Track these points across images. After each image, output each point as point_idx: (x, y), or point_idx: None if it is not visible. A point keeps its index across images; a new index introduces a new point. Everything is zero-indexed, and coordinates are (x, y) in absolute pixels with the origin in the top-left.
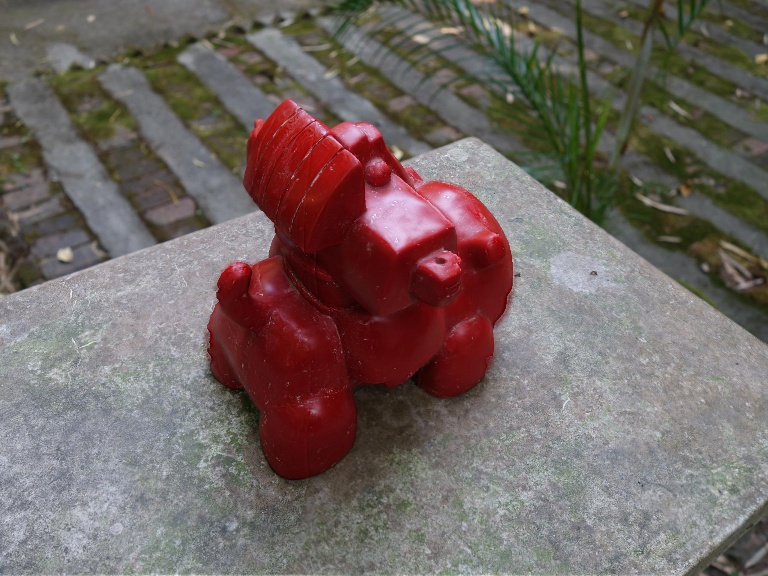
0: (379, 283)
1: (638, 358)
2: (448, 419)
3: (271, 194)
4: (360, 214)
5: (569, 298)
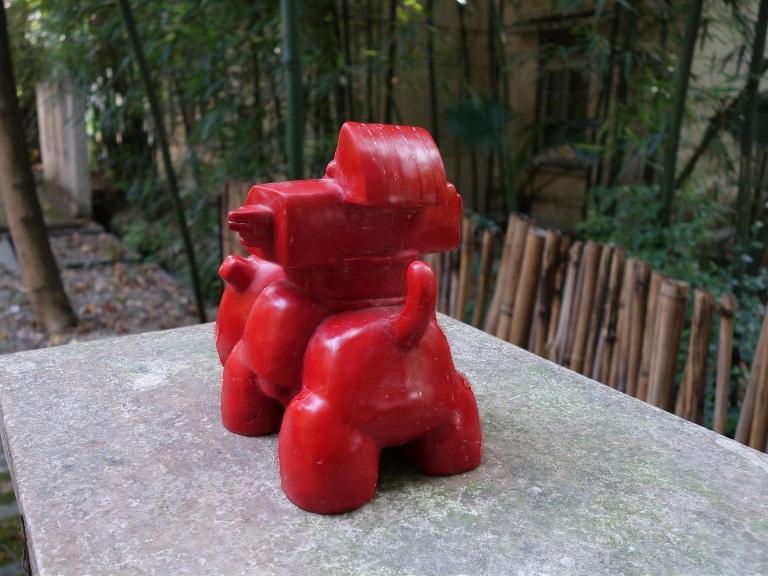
0: (456, 214)
1: None
2: None
3: (411, 180)
4: None
5: None
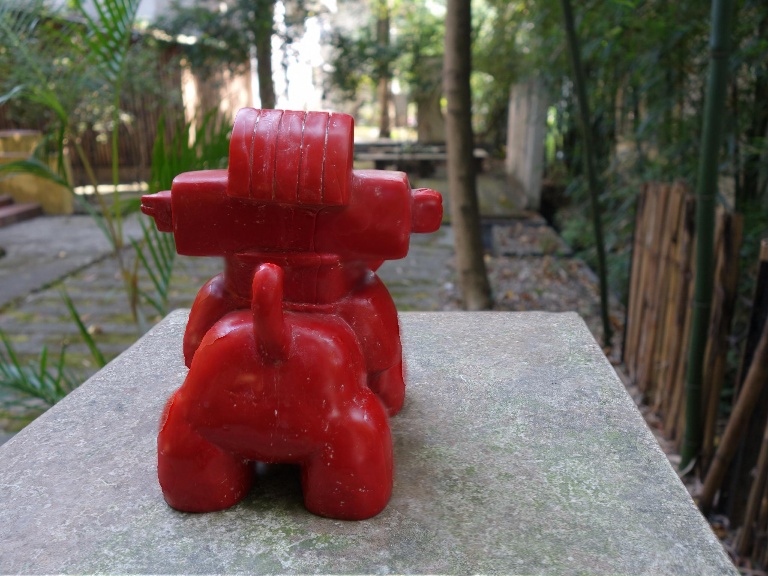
0: (400, 217)
1: (460, 344)
2: (416, 421)
3: (285, 171)
4: (353, 174)
5: None
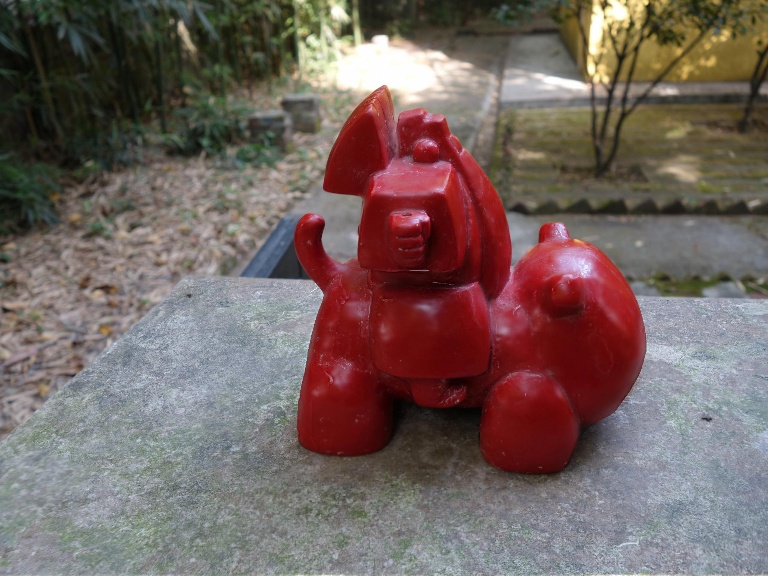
0: None
1: None
2: (478, 483)
3: None
4: (377, 169)
5: (757, 465)
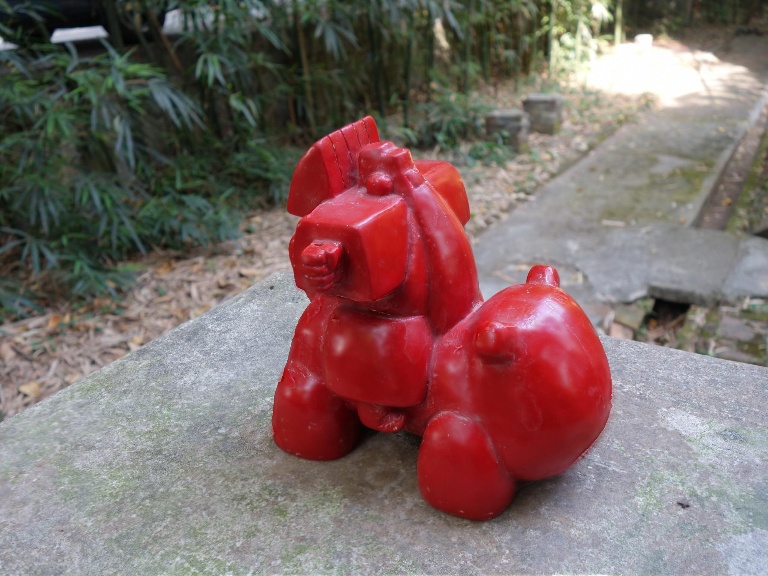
0: None
1: None
2: (400, 511)
3: None
4: (326, 198)
5: (705, 569)
